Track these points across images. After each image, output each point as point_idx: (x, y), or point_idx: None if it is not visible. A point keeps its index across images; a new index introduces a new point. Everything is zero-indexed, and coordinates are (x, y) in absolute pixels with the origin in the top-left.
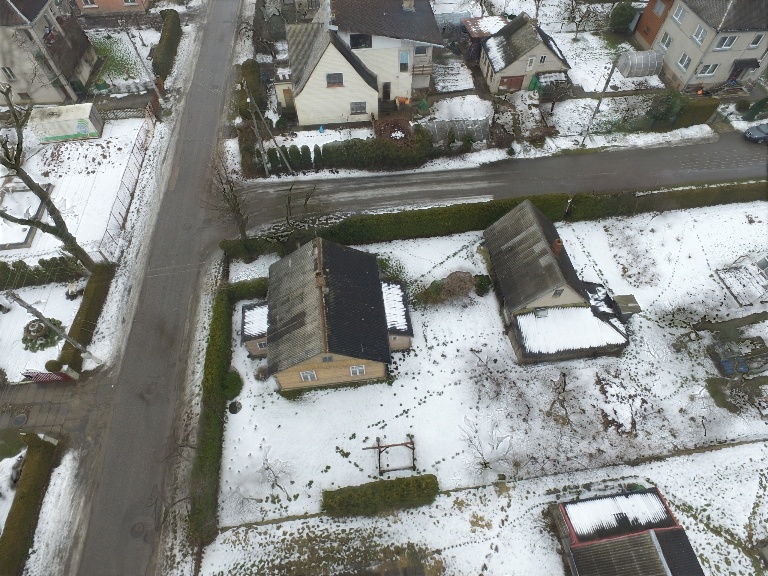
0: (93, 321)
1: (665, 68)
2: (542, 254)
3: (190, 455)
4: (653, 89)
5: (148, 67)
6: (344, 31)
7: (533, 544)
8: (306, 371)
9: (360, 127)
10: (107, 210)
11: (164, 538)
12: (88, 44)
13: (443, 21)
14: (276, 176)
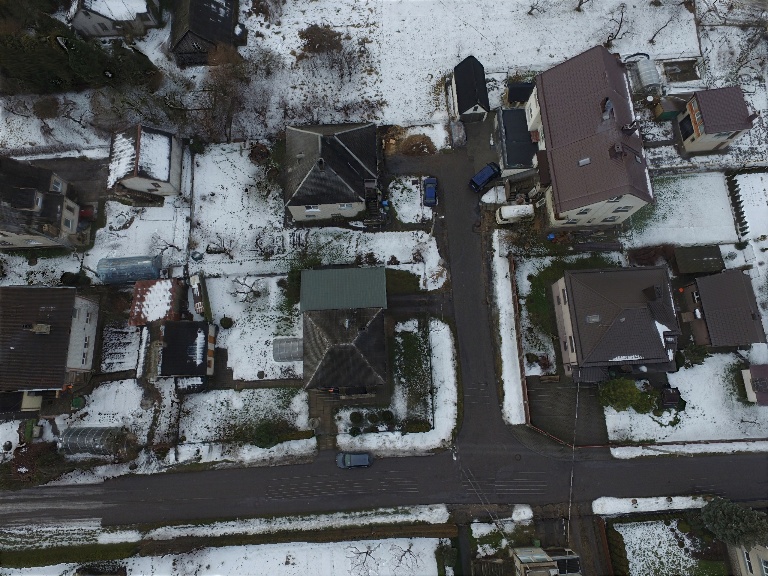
0: None
1: None
2: None
3: None
4: (294, 380)
5: None
6: None
7: None
8: None
9: (23, 419)
10: None
11: None
12: None
13: (126, 273)
14: None
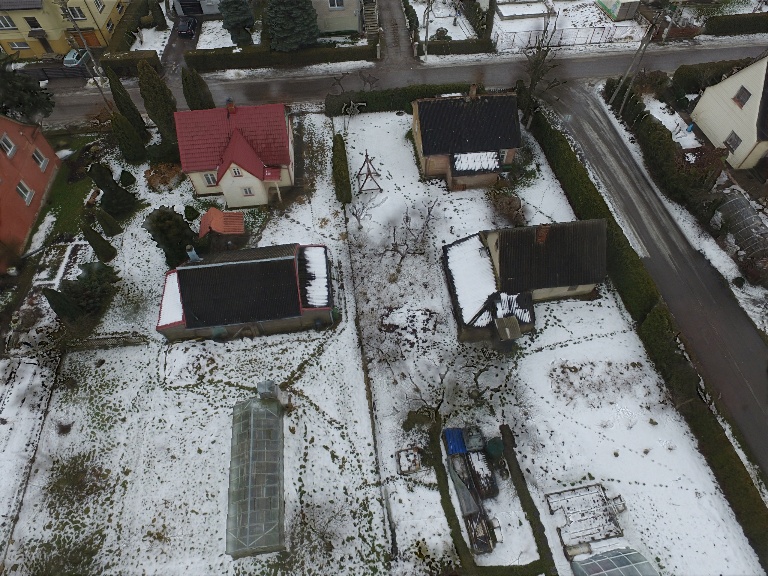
0: (452, 52)
1: None
2: None
3: None
4: None
5: None
6: None
7: None
8: None
9: None
10: None
11: None
12: None
13: None
14: (610, 107)
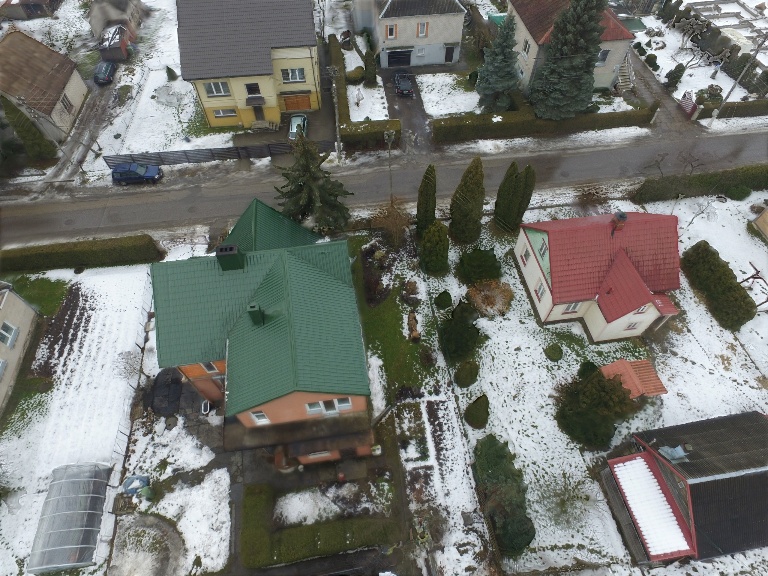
0: (735, 114)
1: None
2: None
3: None
4: None
5: None
6: None
7: (730, 403)
8: None
9: None
10: None
11: (626, 181)
12: None
13: None
14: None
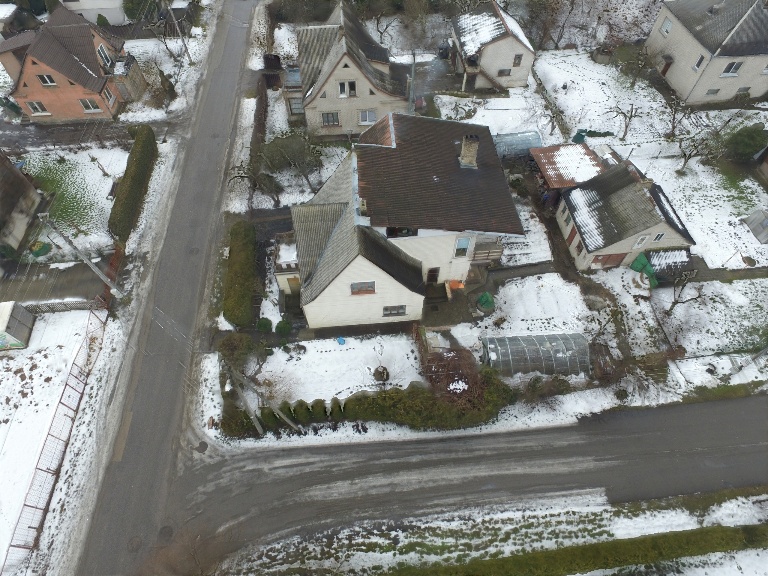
0: None
1: None
2: None
3: None
4: None
5: (107, 213)
6: (379, 225)
7: None
8: None
9: (396, 333)
10: (15, 506)
11: None
12: (23, 190)
13: (503, 147)
14: (274, 436)
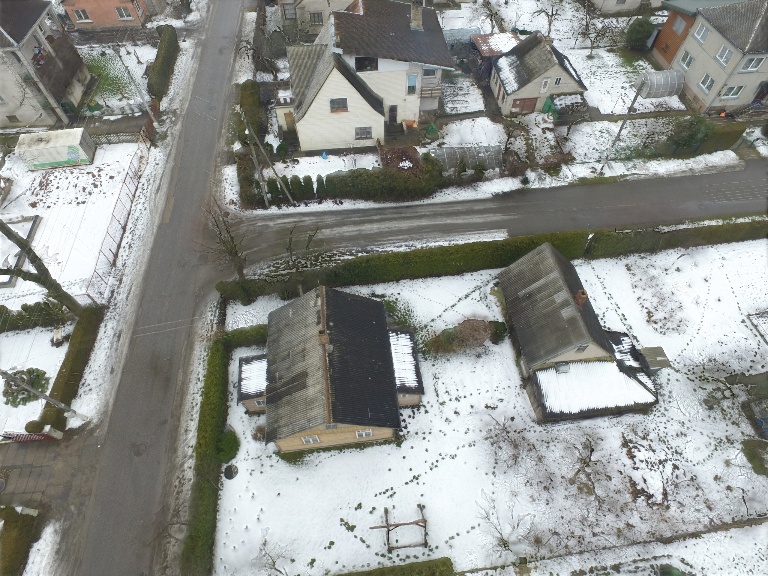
0: (79, 372)
1: (685, 88)
2: (564, 305)
3: (181, 528)
4: (673, 111)
5: (143, 86)
6: (349, 54)
7: None
8: (308, 436)
9: (365, 153)
10: (97, 245)
11: None
12: (80, 63)
13: (452, 37)
14: (276, 207)
